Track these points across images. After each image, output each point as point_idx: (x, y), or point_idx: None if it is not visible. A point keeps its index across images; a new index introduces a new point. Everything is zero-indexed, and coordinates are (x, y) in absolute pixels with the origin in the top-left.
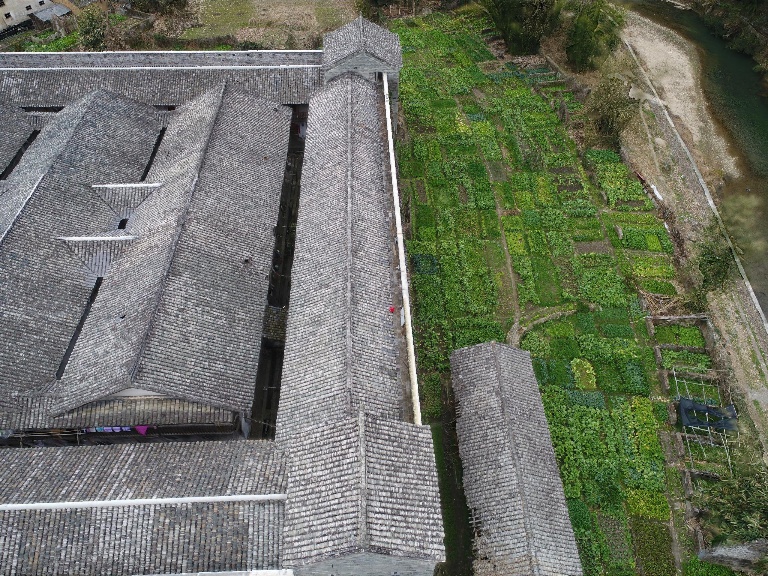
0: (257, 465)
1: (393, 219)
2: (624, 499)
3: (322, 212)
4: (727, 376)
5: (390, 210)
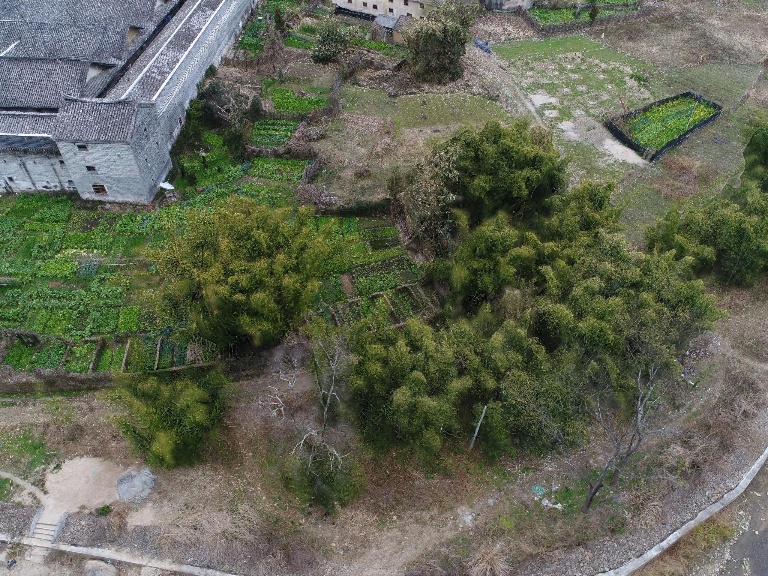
0: None
1: None
2: None
3: None
4: None
5: None
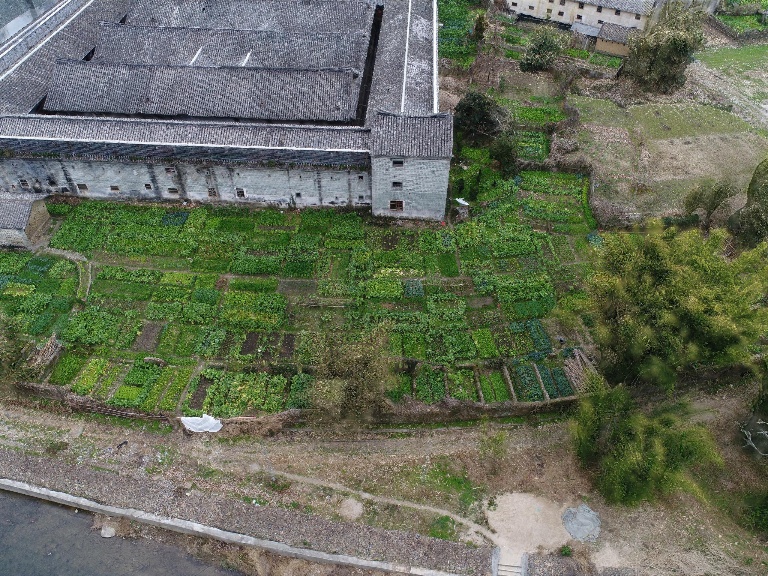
0: (5, 107)
1: None
2: None
3: None
4: None
5: None
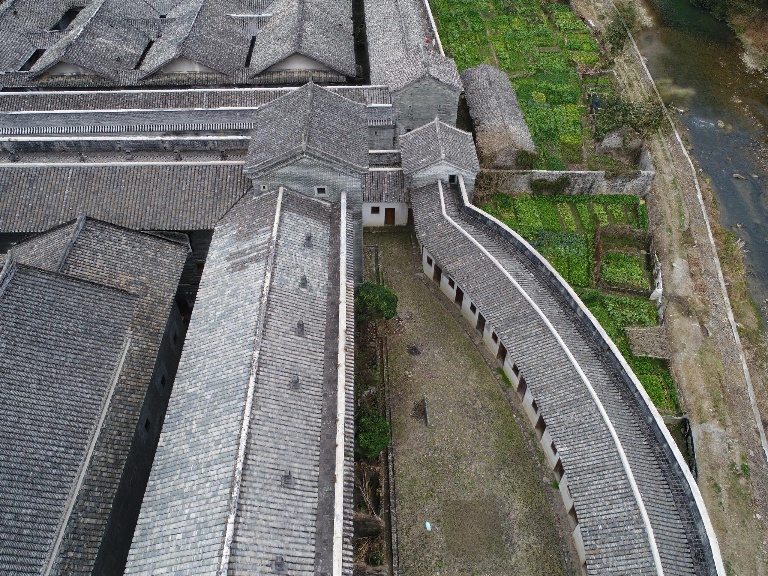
0: None
1: (424, 11)
2: (558, 137)
3: (380, 7)
4: (621, 92)
5: (421, 8)
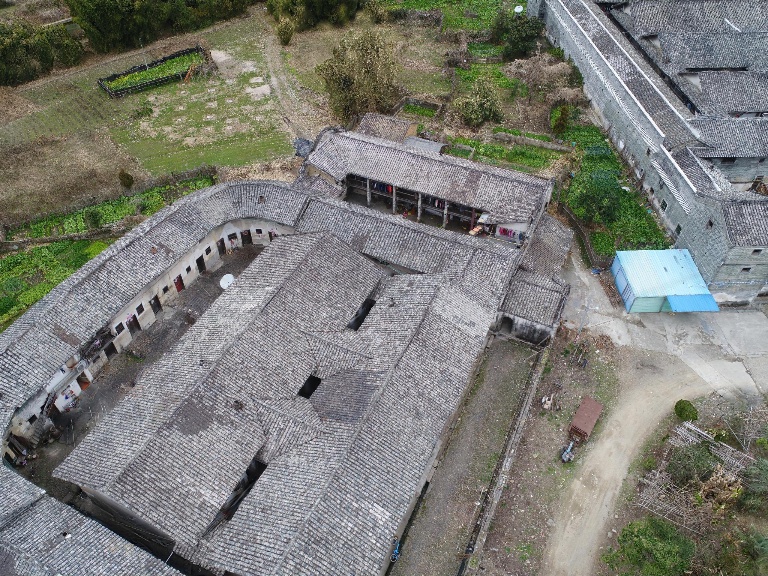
0: None
1: None
2: None
3: None
4: None
5: None
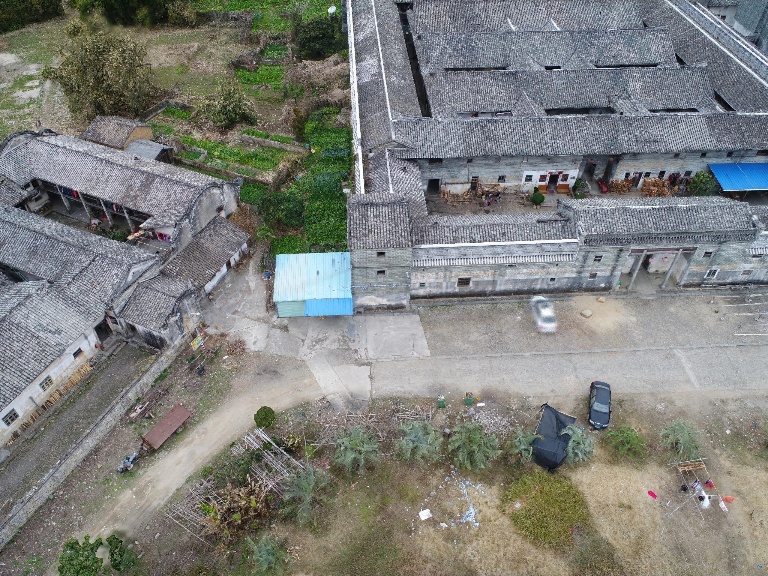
0: None
1: None
2: None
3: None
4: None
5: None
